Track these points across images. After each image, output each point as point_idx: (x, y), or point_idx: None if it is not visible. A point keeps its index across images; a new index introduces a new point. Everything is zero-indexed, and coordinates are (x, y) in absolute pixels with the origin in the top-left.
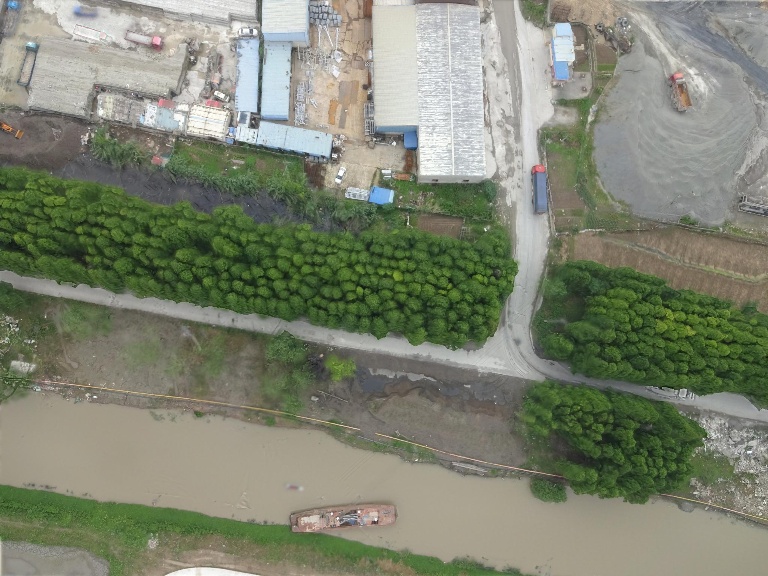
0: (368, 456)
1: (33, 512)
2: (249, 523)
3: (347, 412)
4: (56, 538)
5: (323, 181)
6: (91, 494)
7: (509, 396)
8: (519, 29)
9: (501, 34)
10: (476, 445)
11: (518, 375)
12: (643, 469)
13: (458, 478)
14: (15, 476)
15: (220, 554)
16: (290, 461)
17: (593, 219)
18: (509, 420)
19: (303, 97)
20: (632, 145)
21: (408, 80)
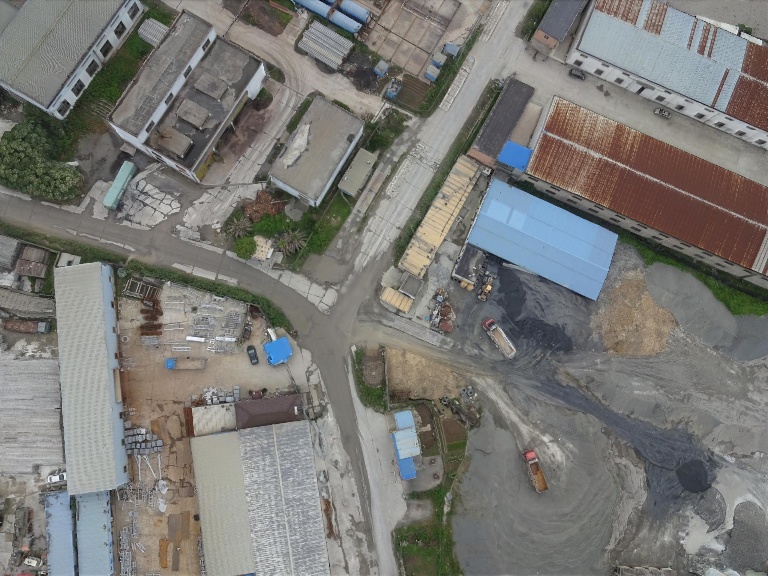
0: None
1: None
2: None
3: None
4: None
5: None
6: None
7: None
8: (359, 418)
9: (340, 427)
10: None
11: None
12: None
13: None
14: None
15: None
16: None
17: None
18: None
19: (128, 543)
20: (491, 547)
21: (238, 520)
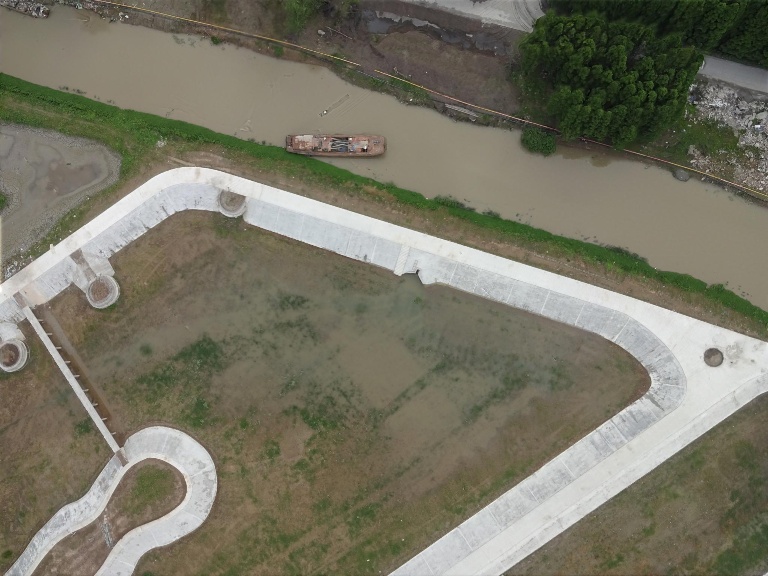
0: (366, 94)
1: (64, 106)
2: (249, 141)
3: (350, 48)
4: (80, 129)
5: None
6: (114, 101)
7: (510, 48)
8: None
9: None
10: (470, 85)
11: (521, 29)
12: (631, 86)
13: (450, 123)
14: (53, 81)
15: (219, 157)
16: (293, 95)
17: None
18: (506, 65)
19: None
20: None
21: None
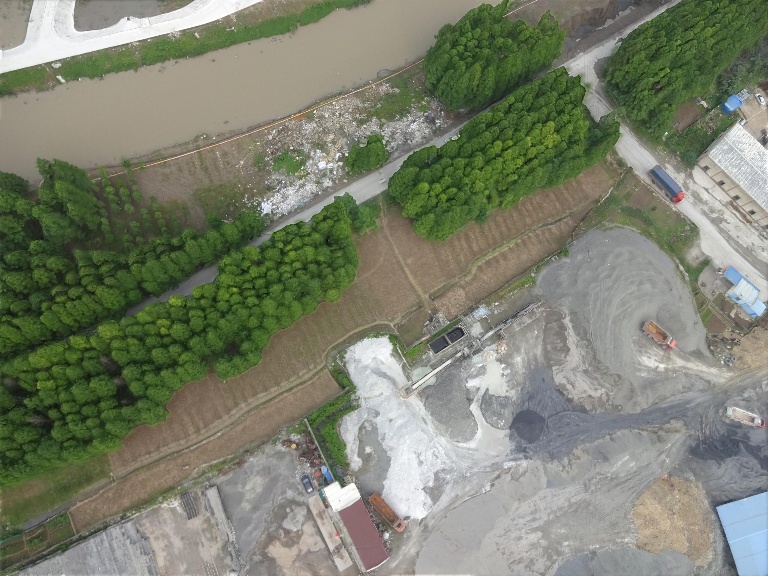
0: None
1: None
2: None
3: None
4: None
5: (762, 89)
6: None
7: None
8: None
9: None
10: (547, 5)
11: None
12: None
13: None
14: None
15: None
16: None
17: (614, 202)
18: None
19: None
20: (654, 259)
21: None
